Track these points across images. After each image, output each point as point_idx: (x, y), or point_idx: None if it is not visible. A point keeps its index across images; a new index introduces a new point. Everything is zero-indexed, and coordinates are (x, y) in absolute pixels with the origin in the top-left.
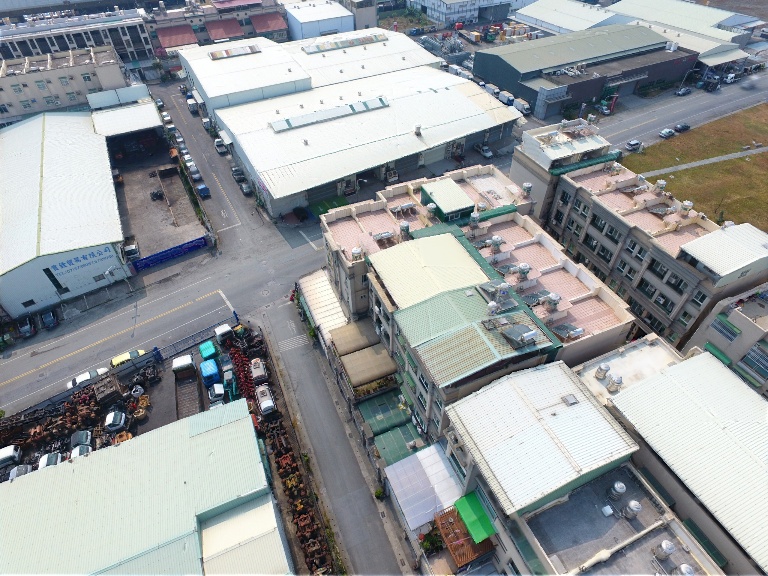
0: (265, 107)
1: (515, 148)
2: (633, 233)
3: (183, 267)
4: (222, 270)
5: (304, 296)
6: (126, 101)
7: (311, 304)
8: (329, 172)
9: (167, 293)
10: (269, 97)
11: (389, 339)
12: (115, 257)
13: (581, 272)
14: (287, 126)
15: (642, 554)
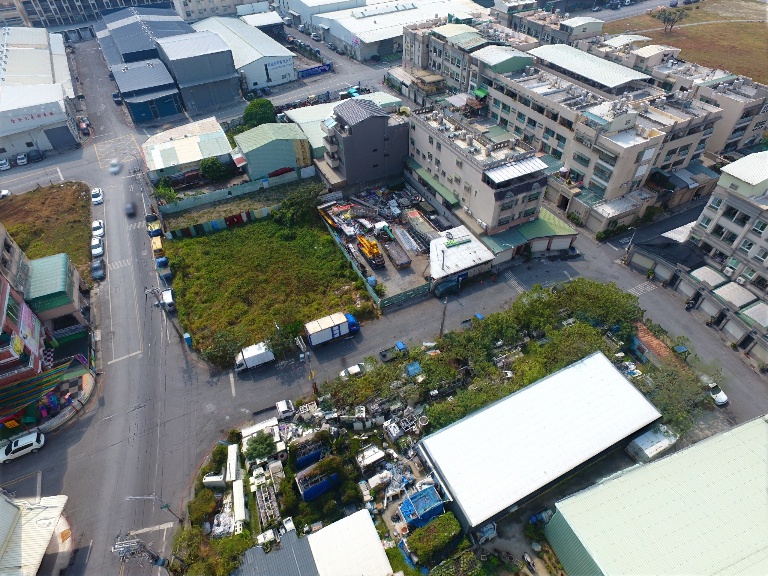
0: (343, 12)
1: (491, 8)
2: (544, 29)
3: (321, 77)
4: (342, 77)
5: (392, 75)
6: (256, 12)
7: (397, 76)
8: (391, 34)
9: (318, 84)
10: (342, 9)
11: (440, 68)
12: (292, 65)
13: (520, 35)
14: (362, 15)
15: (534, 80)
